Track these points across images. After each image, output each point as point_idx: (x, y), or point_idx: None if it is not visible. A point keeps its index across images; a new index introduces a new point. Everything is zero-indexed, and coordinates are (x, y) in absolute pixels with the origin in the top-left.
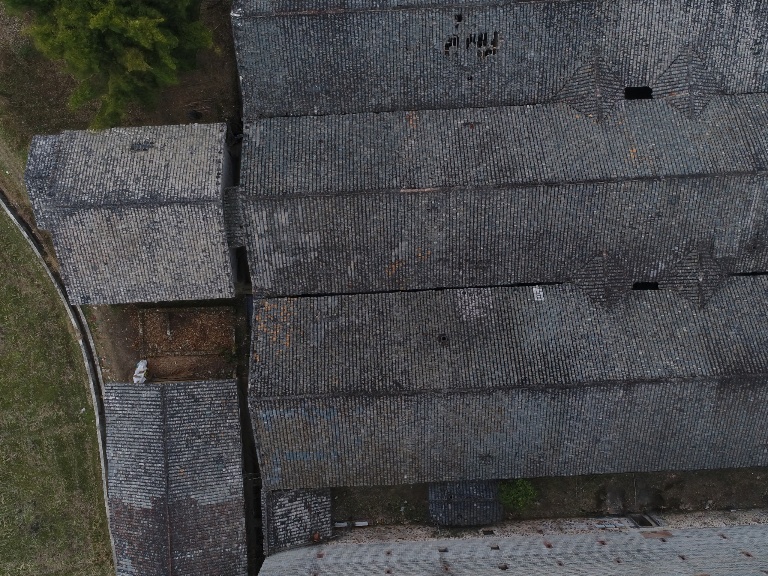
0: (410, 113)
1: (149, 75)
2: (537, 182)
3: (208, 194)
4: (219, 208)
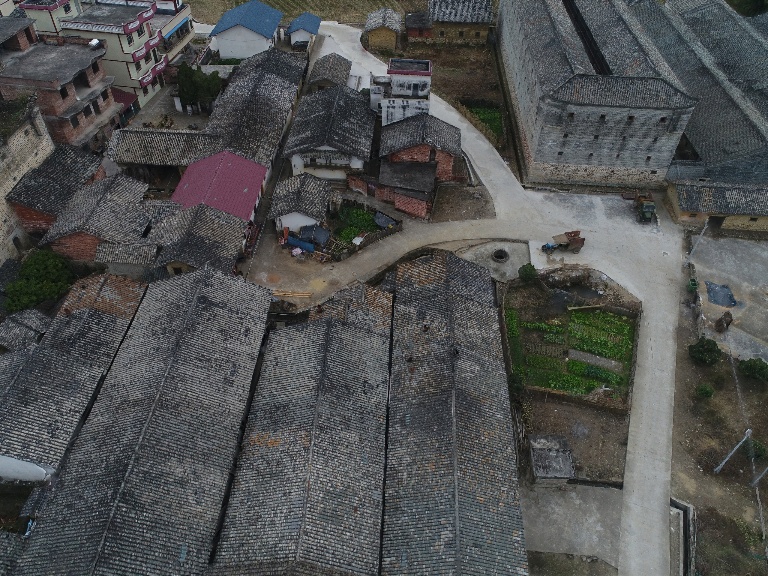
0: (767, 41)
1: (749, 2)
2: (760, 43)
3: (717, 1)
4: (713, 2)
